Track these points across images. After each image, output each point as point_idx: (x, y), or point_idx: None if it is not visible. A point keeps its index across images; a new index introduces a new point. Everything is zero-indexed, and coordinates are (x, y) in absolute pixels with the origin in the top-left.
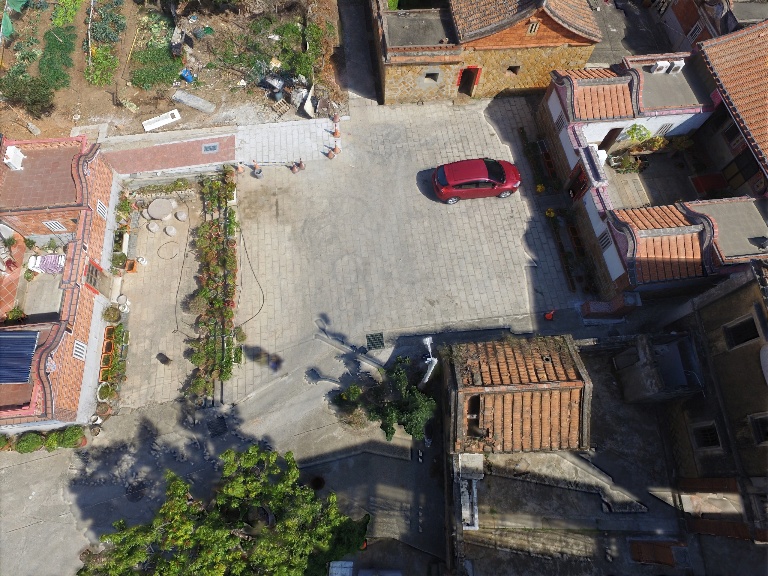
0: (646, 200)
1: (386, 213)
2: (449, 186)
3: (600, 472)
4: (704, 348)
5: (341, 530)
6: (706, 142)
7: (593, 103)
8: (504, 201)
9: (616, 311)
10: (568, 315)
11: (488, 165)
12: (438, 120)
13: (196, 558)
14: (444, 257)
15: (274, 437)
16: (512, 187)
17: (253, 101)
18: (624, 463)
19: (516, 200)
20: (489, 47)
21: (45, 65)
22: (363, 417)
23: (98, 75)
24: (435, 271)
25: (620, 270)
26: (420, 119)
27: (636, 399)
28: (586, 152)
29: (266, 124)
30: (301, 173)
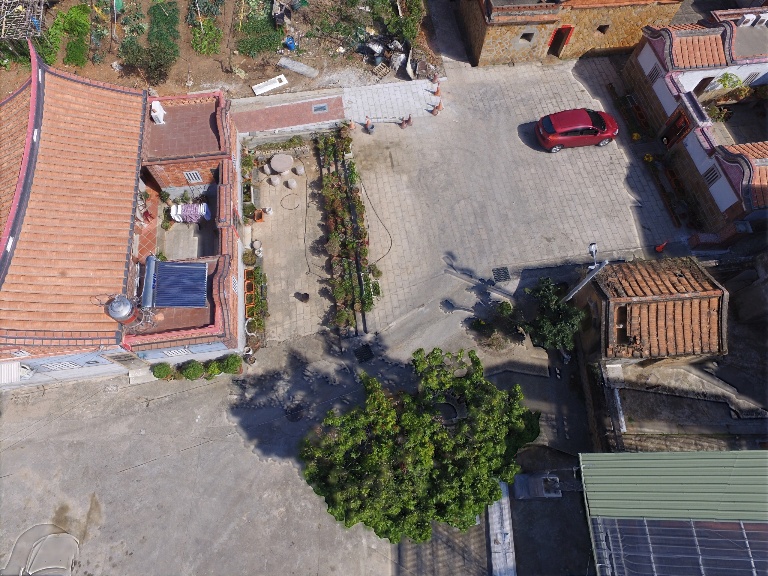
0: None
1: (494, 162)
2: (556, 134)
3: (725, 384)
4: None
5: (524, 419)
6: None
7: (689, 53)
8: (602, 149)
9: (725, 240)
10: (677, 248)
11: None
12: (530, 79)
13: (409, 438)
14: (554, 199)
15: None
16: (612, 135)
17: (353, 66)
18: (746, 376)
19: (613, 148)
20: (585, 6)
21: (154, 37)
22: (501, 340)
23: (205, 45)
24: (547, 212)
25: (732, 200)
26: (513, 78)
27: (755, 316)
28: (688, 96)
29: (369, 86)
30: (409, 128)
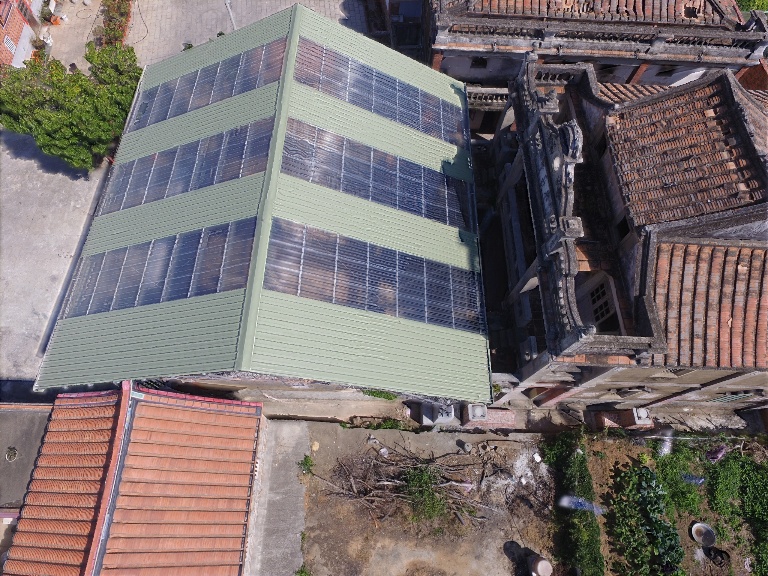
0: None
1: None
2: None
3: None
4: None
5: None
6: None
7: None
8: None
9: None
10: None
11: None
12: None
13: None
14: None
15: None
16: None
17: None
18: None
19: None
20: None
21: None
22: None
23: None
24: None
25: None
26: None
27: None
28: None
29: None
30: None
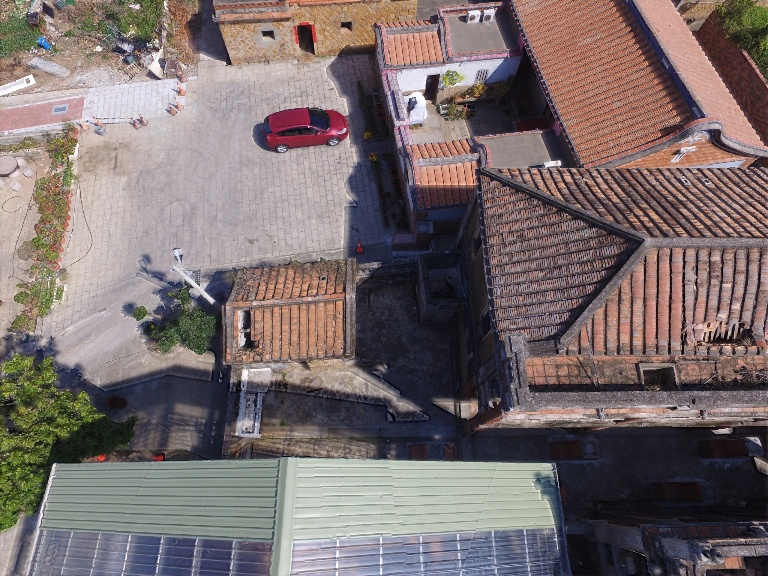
0: None
1: (219, 163)
2: (272, 133)
3: (389, 386)
4: (467, 262)
5: (94, 426)
6: (531, 89)
7: (403, 50)
8: (334, 149)
9: (416, 241)
10: (379, 249)
11: (314, 114)
12: (281, 77)
13: None
14: (269, 200)
15: (86, 365)
16: (337, 134)
17: (107, 65)
18: (413, 378)
19: (345, 147)
20: (312, 3)
21: None
22: None
23: None
24: (258, 213)
25: None
26: (264, 77)
27: (423, 318)
28: (392, 95)
29: (116, 86)
30: (143, 129)
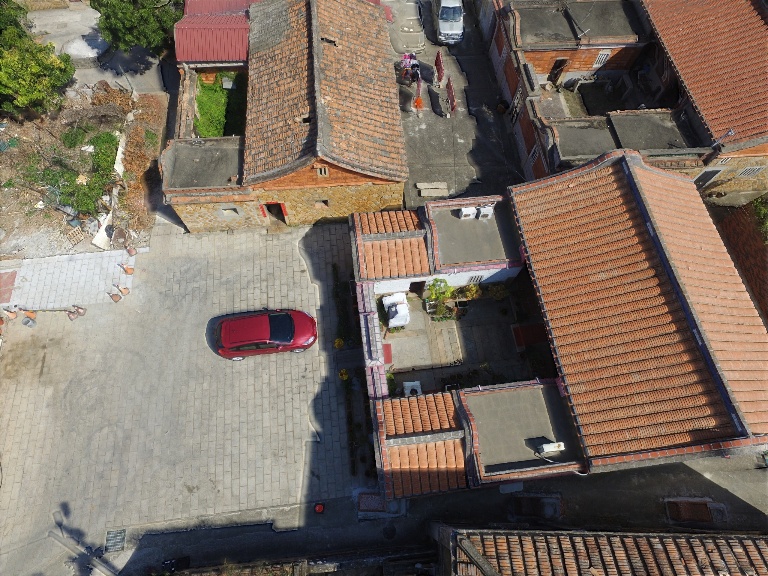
0: (458, 355)
1: (163, 372)
2: (225, 348)
3: None
4: None
5: None
6: None
7: (383, 260)
8: (299, 356)
9: None
10: (342, 506)
11: (277, 319)
12: (246, 253)
13: None
14: (217, 429)
15: None
16: (302, 345)
17: (49, 227)
18: None
19: (313, 355)
20: (280, 188)
21: None
22: None
23: None
24: (203, 448)
25: None
26: (226, 251)
27: None
28: (366, 321)
29: (55, 257)
30: (79, 320)
